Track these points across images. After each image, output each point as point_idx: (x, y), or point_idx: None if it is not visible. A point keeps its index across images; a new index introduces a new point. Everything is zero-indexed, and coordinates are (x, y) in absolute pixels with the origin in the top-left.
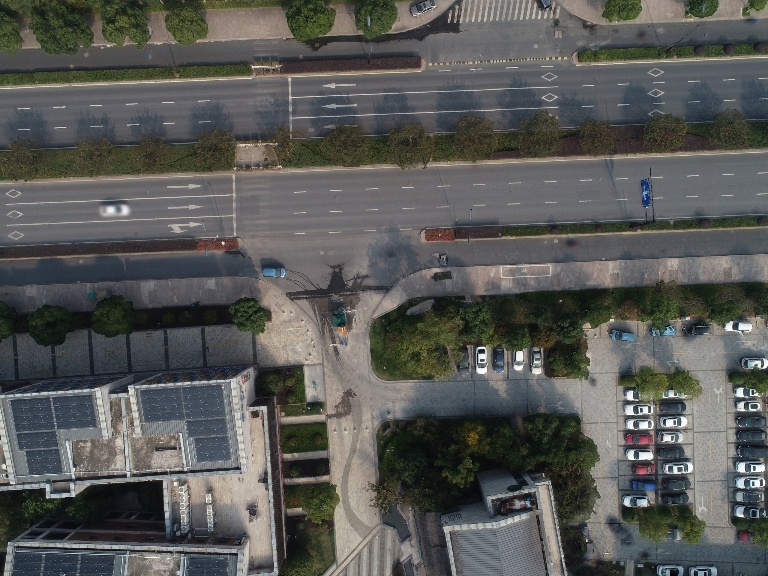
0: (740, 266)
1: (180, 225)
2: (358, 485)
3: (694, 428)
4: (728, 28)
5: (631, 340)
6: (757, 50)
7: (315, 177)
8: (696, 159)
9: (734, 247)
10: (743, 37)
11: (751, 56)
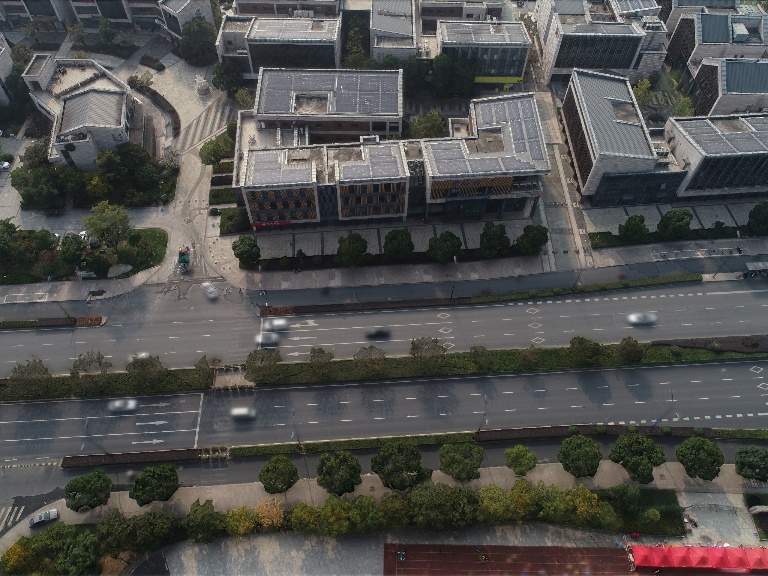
0: None
1: (307, 325)
2: (193, 173)
3: None
4: None
5: None
6: None
7: (187, 363)
8: None
9: None
10: None
11: None
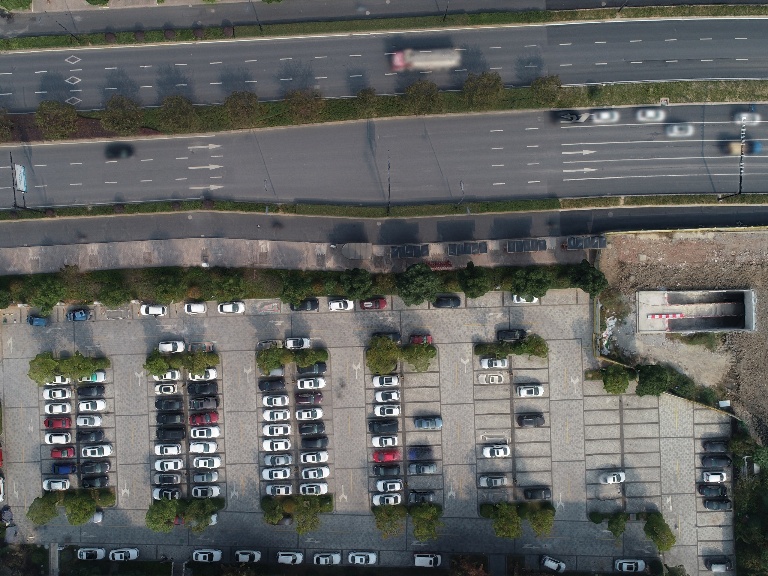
0: (160, 251)
1: None
2: None
3: (116, 412)
4: (144, 15)
5: (42, 325)
6: (166, 37)
7: None
8: (114, 145)
9: (154, 232)
10: (159, 24)
11: (166, 43)
